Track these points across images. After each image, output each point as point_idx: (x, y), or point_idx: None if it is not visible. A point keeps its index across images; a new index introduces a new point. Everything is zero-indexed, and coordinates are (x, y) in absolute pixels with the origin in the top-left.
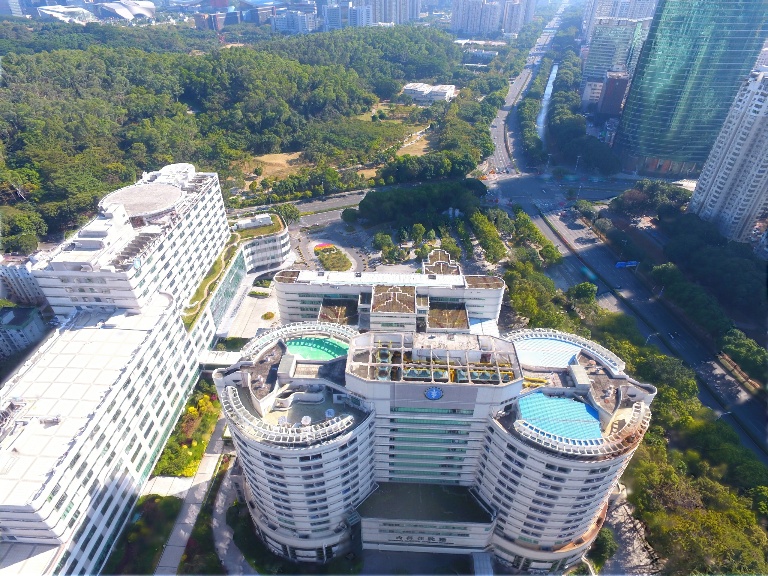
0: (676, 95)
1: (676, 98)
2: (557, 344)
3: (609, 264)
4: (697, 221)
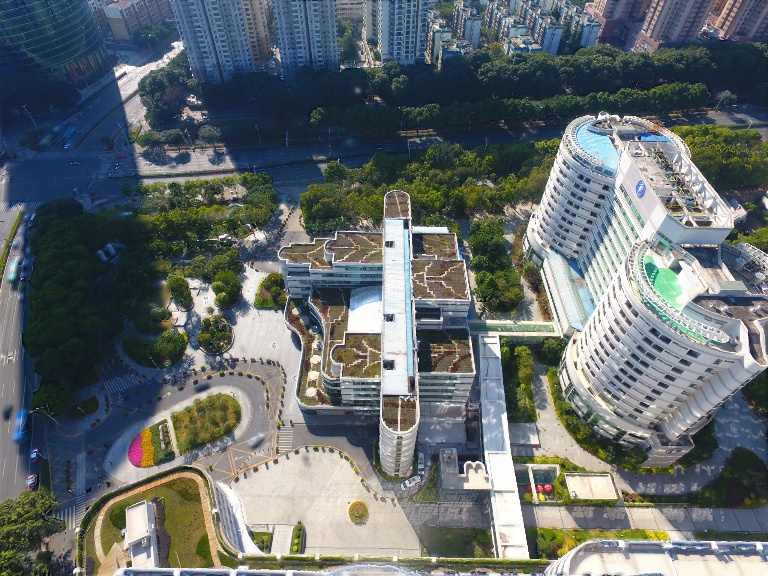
0: None
1: None
2: (581, 138)
3: (268, 154)
4: (252, 76)
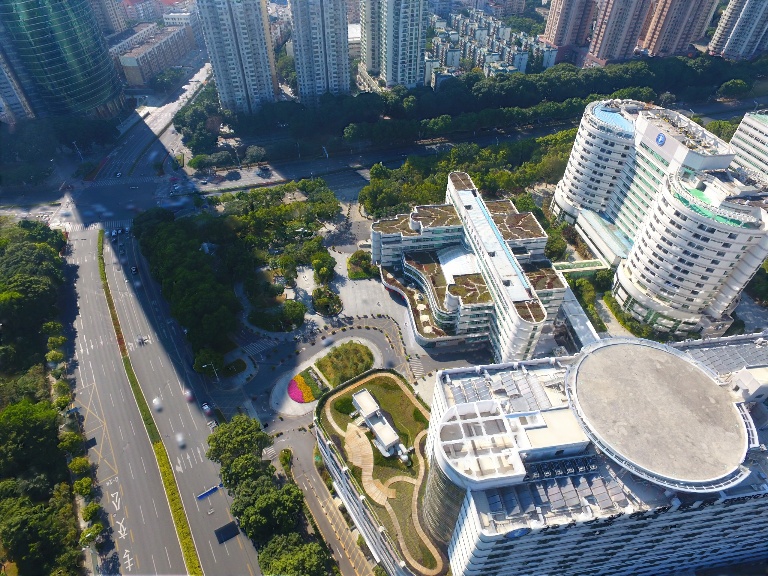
0: (71, 29)
1: (73, 32)
2: (599, 115)
3: (310, 166)
4: (282, 104)
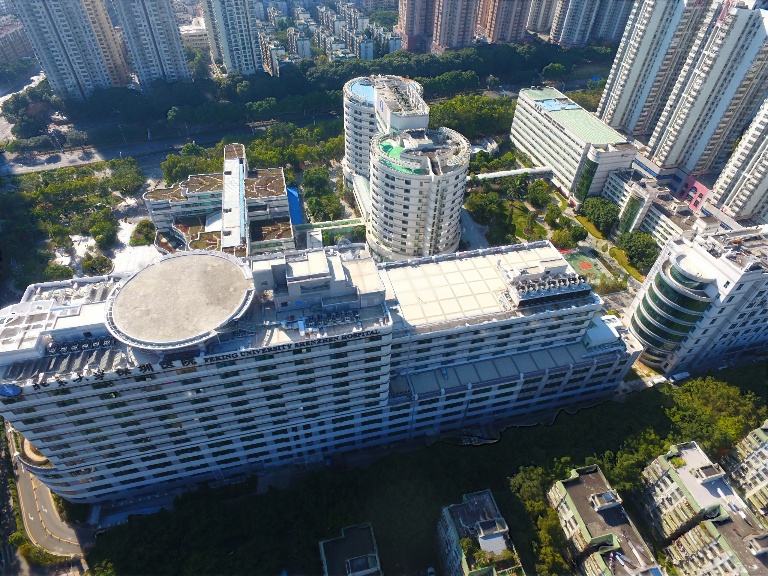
0: None
1: None
2: (354, 88)
3: (134, 149)
4: (111, 90)
